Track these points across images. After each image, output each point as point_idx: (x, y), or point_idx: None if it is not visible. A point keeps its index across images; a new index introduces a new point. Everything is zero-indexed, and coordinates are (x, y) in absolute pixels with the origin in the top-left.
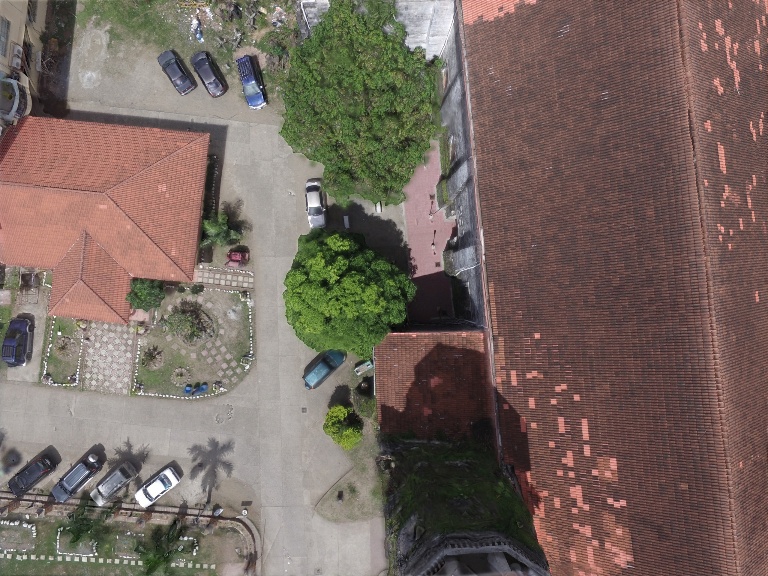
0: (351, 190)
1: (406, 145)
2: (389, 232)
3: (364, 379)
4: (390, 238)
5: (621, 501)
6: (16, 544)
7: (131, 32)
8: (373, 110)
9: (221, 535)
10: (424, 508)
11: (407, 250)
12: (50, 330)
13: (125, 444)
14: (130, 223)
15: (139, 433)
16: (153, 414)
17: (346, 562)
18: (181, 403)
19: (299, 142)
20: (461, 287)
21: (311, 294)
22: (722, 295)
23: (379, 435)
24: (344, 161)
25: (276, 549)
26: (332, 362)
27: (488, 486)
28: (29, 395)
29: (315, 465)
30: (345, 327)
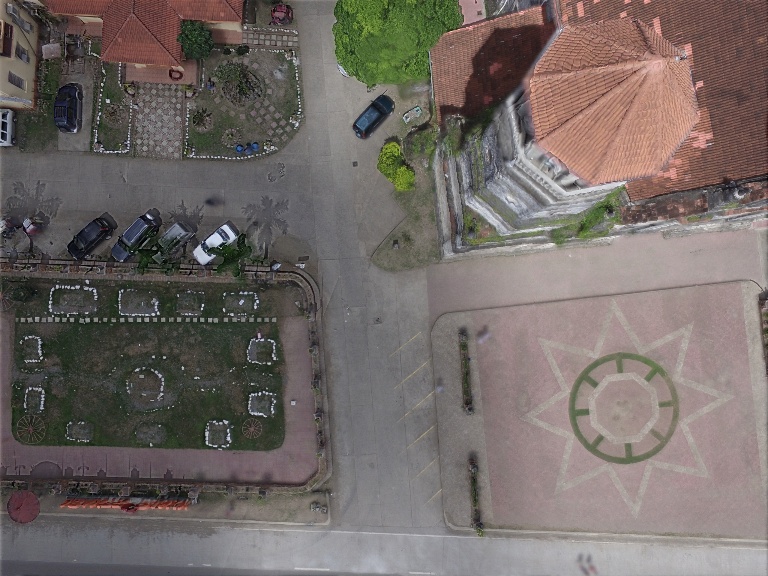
0: None
1: None
2: None
3: None
4: None
5: (698, 83)
6: (78, 307)
7: None
8: None
9: (280, 289)
10: None
11: None
12: (98, 98)
13: (180, 207)
14: None
15: (193, 196)
16: (206, 176)
17: (404, 309)
18: (233, 164)
19: None
20: None
21: None
22: None
23: (440, 135)
24: None
25: (335, 301)
26: (381, 109)
27: None
28: (81, 164)
29: (369, 217)
30: (403, 17)
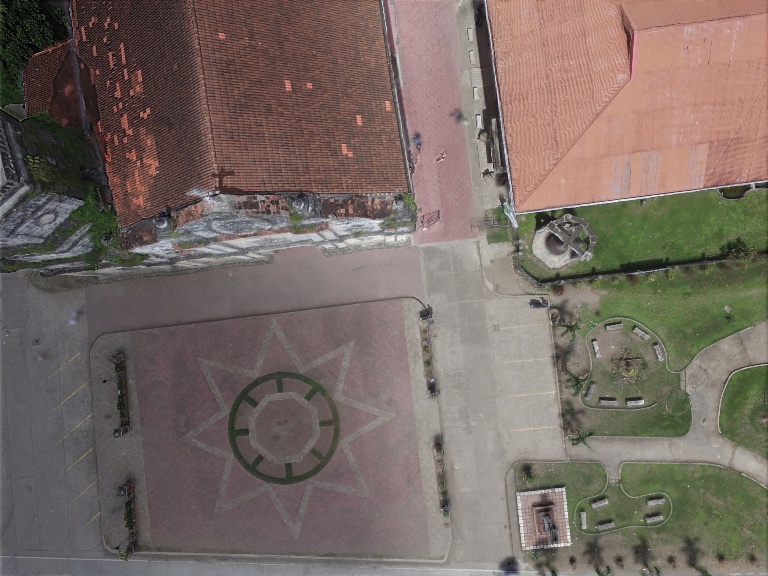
0: None
1: None
2: None
3: None
4: None
5: (146, 110)
6: None
7: None
8: None
9: None
10: None
11: None
12: None
13: None
14: None
15: None
16: None
17: (63, 330)
18: None
19: None
20: None
21: None
22: None
23: None
24: None
25: None
26: None
27: None
28: None
29: None
30: None
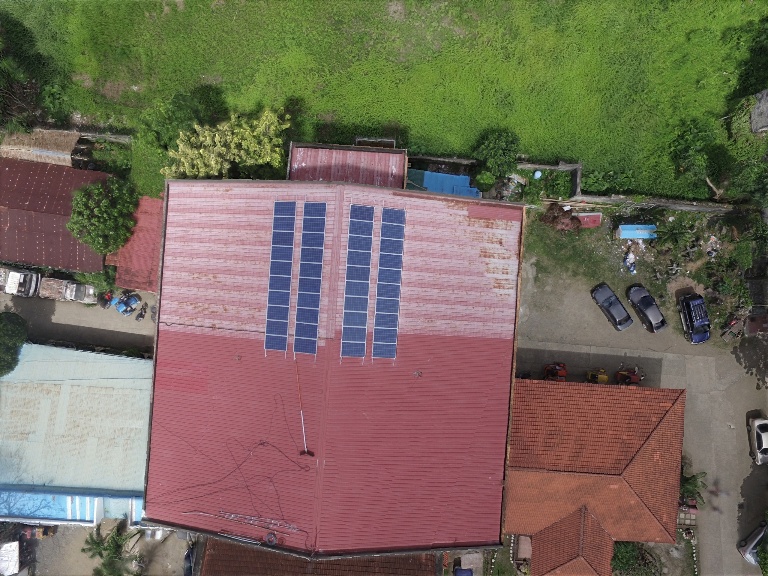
0: None
1: None
2: None
3: None
4: None
5: None
6: None
7: (558, 265)
8: None
9: None
10: None
11: None
12: (489, 575)
13: None
14: (635, 499)
15: None
16: None
17: None
18: None
19: None
20: None
21: None
22: None
23: None
24: None
25: None
26: None
27: None
28: None
29: None
30: None
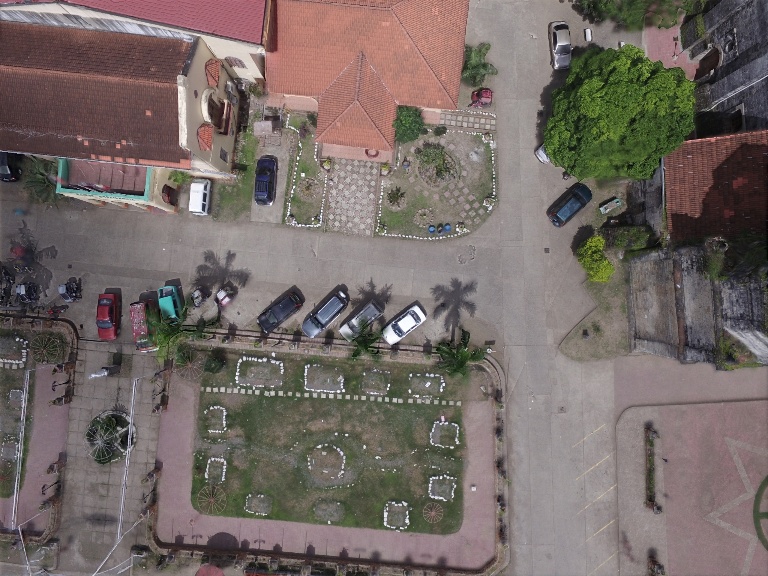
0: None
1: None
2: None
3: (609, 218)
4: None
5: None
6: (264, 380)
7: None
8: None
9: (466, 373)
10: None
11: None
12: (293, 172)
13: (368, 284)
14: (409, 42)
15: (382, 273)
16: (396, 255)
17: (590, 400)
18: (424, 244)
19: None
20: (718, 119)
21: (621, 92)
22: None
23: (670, 243)
24: None
25: (520, 387)
26: (581, 199)
27: None
28: (272, 236)
29: (558, 305)
30: (650, 128)
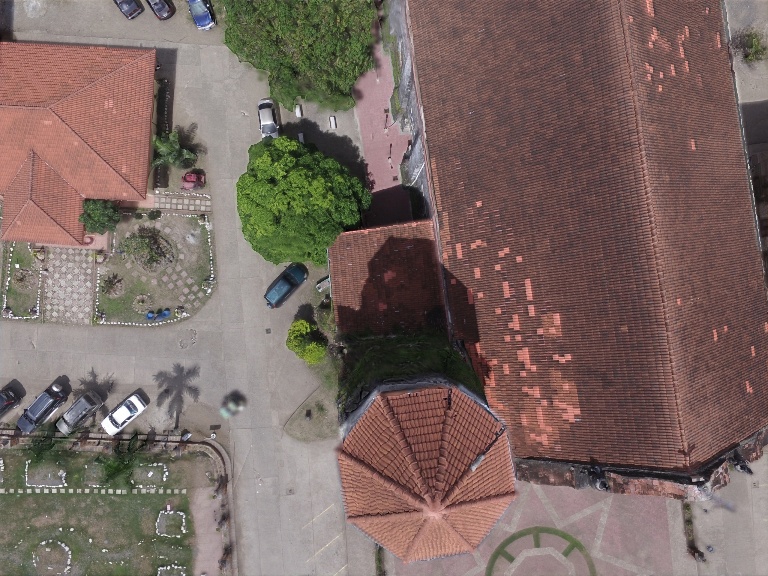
0: (295, 88)
1: (347, 36)
2: (345, 148)
3: (327, 296)
4: (346, 154)
5: (566, 355)
6: None
7: None
8: (311, 0)
9: (191, 460)
10: (370, 375)
11: (364, 165)
12: (8, 263)
13: (90, 374)
14: (77, 139)
15: (103, 362)
16: (116, 343)
17: (317, 480)
18: (144, 330)
19: (243, 48)
20: (418, 195)
21: (258, 192)
22: (653, 132)
23: (337, 336)
24: (286, 57)
25: (247, 471)
26: (293, 279)
27: (434, 352)
28: None
29: (282, 386)
30: (295, 225)
